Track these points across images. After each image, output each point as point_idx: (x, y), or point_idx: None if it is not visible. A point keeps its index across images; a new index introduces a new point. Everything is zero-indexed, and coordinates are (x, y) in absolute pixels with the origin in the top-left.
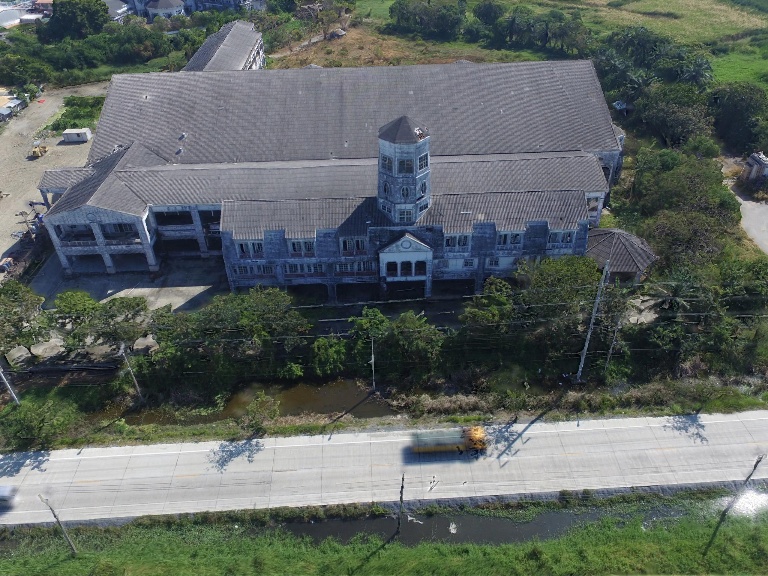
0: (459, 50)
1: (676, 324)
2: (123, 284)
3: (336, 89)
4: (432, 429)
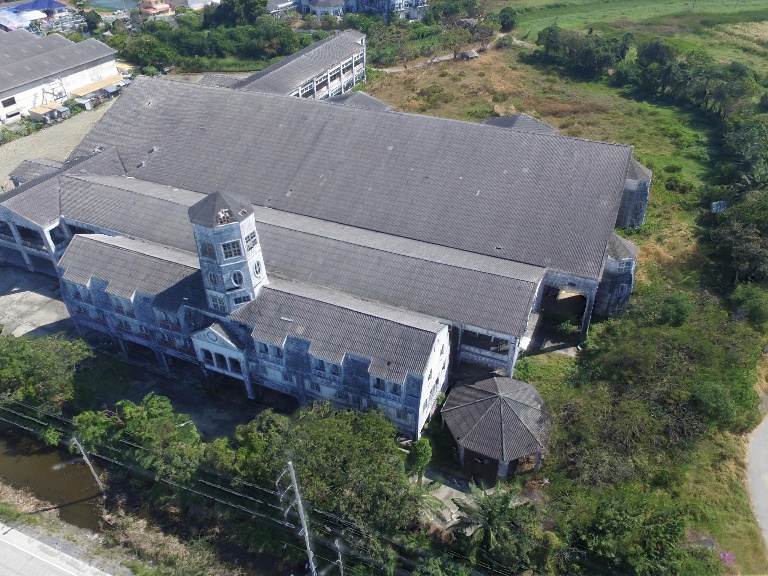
0: (590, 94)
1: (466, 564)
2: (30, 285)
3: (317, 128)
4: (101, 570)
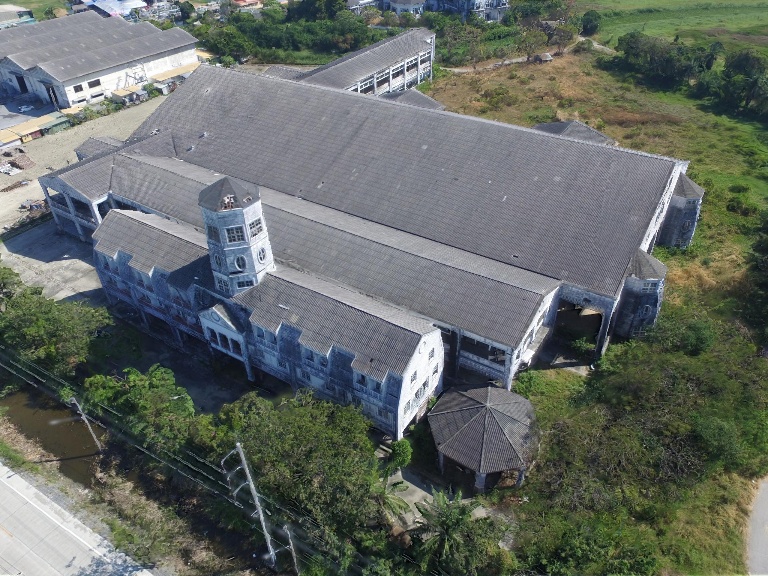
0: (665, 104)
1: (416, 569)
2: (79, 253)
3: (357, 123)
4: (83, 523)
